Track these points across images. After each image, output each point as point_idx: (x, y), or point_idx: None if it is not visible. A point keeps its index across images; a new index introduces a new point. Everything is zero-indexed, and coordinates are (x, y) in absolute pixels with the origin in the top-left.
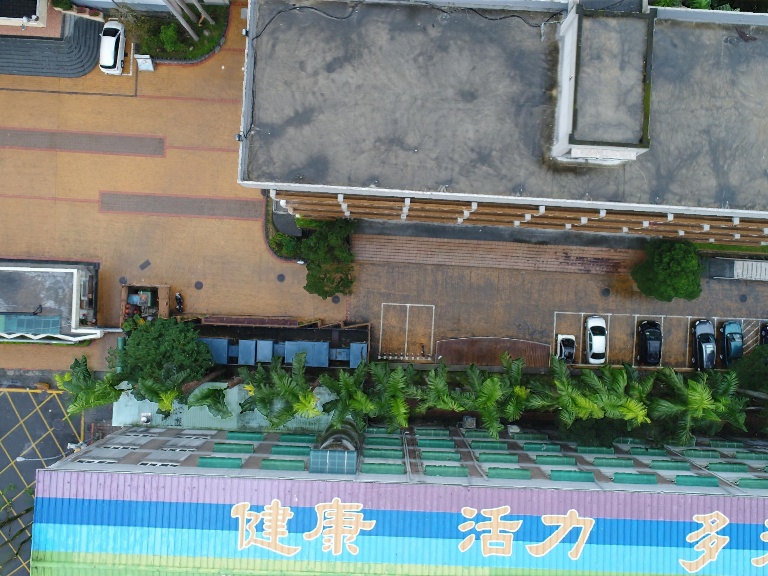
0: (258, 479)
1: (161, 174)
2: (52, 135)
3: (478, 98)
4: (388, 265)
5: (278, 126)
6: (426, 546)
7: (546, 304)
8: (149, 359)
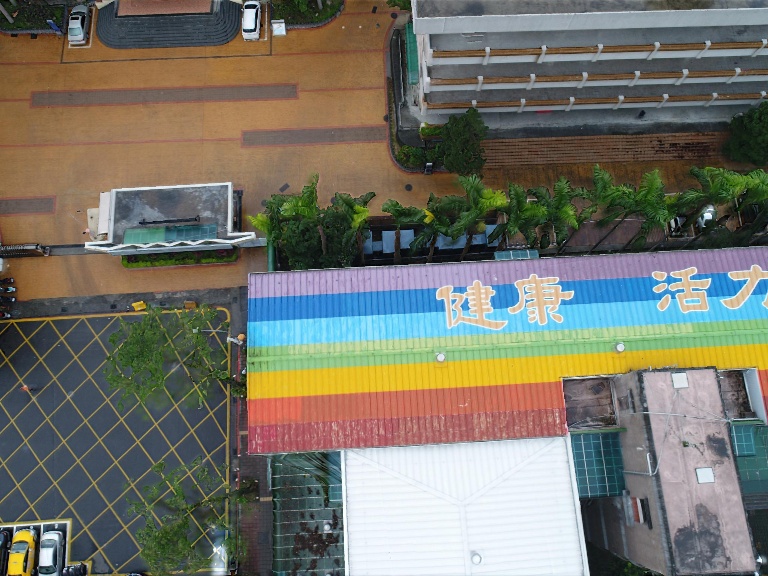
0: (457, 264)
1: (295, 112)
2: (200, 90)
3: None
4: (503, 168)
5: None
6: (626, 309)
7: None
8: (321, 217)
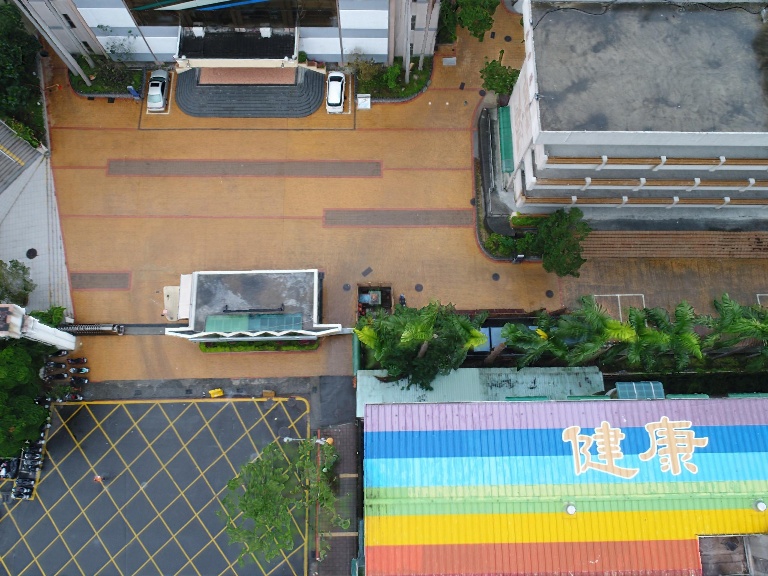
0: (584, 402)
1: (379, 192)
2: (281, 164)
3: (722, 65)
4: (594, 260)
5: (559, 93)
6: (764, 460)
7: (747, 288)
8: None
